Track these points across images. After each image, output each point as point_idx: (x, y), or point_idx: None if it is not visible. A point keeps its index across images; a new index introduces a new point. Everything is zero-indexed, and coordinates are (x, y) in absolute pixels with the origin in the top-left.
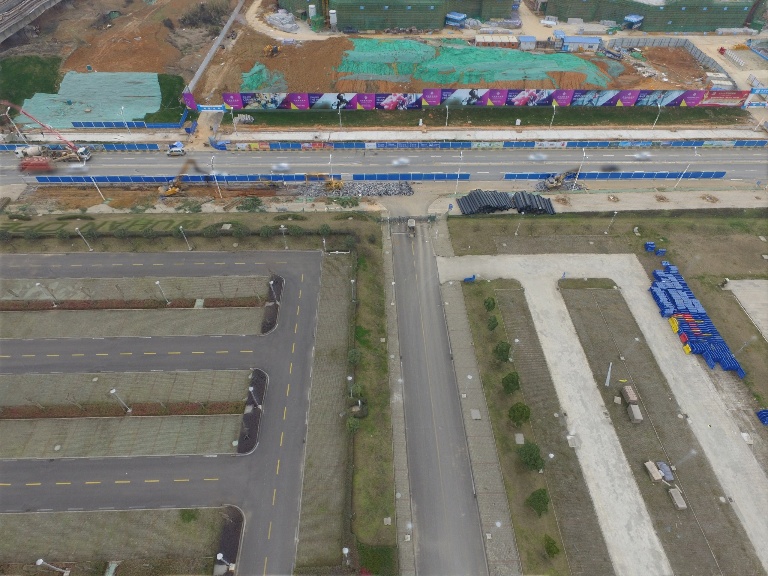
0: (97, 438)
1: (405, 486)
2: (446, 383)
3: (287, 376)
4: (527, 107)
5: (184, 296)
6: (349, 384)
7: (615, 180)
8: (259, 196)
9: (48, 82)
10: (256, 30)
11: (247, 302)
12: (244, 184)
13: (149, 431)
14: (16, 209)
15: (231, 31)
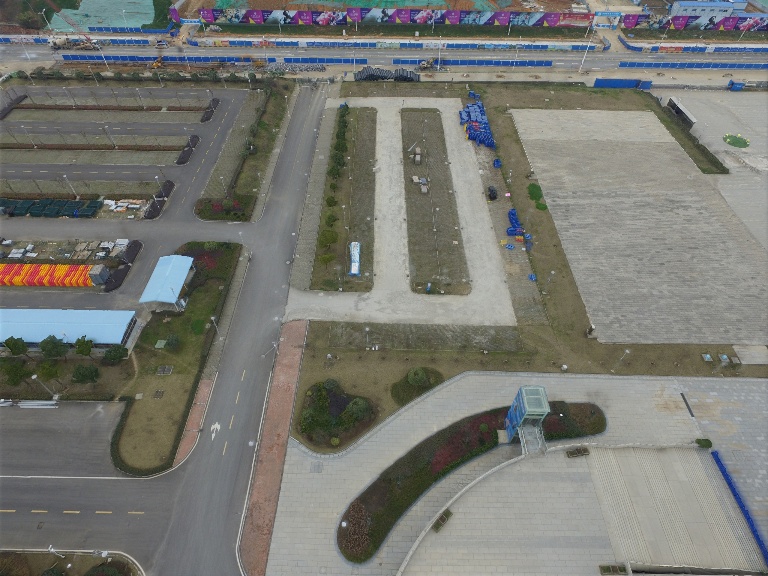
0: (97, 158)
1: (269, 179)
2: (309, 146)
3: (212, 139)
4: (427, 25)
5: (154, 101)
6: (244, 132)
7: (473, 67)
8: (216, 70)
9: (72, 1)
10: None
11: (194, 108)
12: (207, 64)
13: (127, 156)
14: (48, 72)
15: None
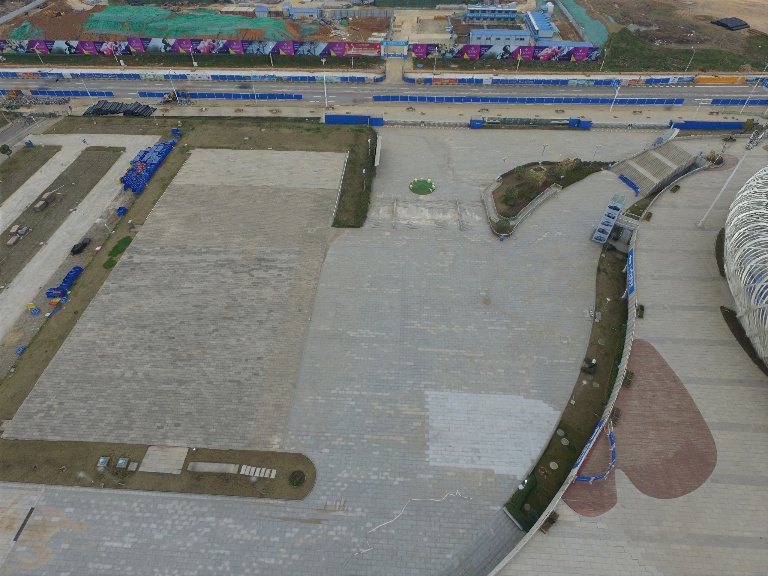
0: None
1: None
2: None
3: None
4: (212, 54)
5: None
6: None
7: (222, 100)
8: None
9: None
10: (67, 3)
11: None
12: None
13: None
14: None
15: (44, 3)
